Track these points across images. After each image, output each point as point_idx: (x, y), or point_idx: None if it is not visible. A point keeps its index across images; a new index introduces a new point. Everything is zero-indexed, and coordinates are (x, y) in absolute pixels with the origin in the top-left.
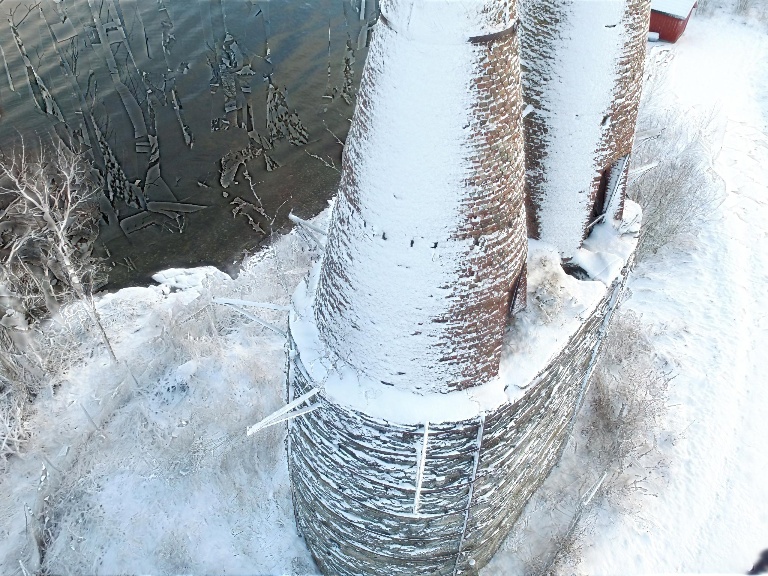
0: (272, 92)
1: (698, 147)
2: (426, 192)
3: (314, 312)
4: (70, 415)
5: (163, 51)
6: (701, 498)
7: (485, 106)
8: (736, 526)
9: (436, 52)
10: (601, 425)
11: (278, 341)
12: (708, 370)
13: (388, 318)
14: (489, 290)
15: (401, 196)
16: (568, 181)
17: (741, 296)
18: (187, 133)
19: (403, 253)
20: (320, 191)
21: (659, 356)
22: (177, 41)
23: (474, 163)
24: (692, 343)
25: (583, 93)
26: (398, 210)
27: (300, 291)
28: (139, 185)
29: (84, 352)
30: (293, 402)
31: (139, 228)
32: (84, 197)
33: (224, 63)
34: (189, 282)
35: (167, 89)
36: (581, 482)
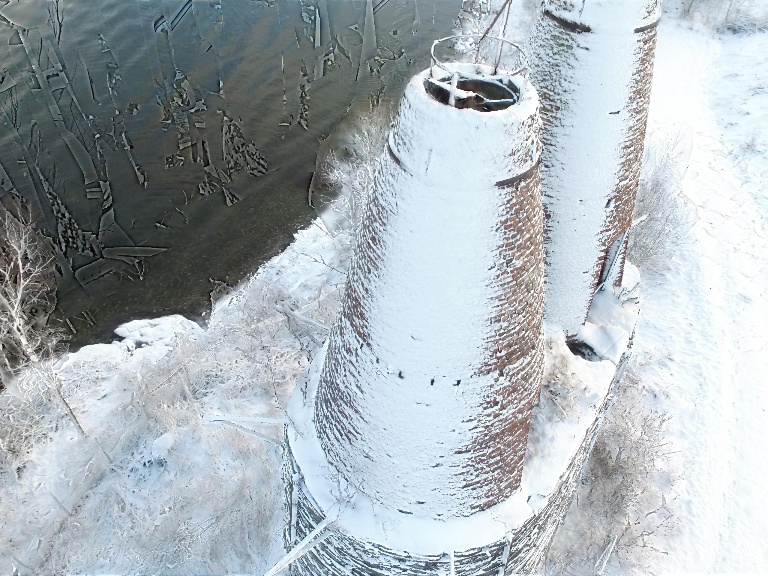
0: (227, 124)
1: (667, 171)
2: (448, 334)
3: (316, 428)
4: (38, 500)
5: (109, 92)
6: (705, 541)
7: (511, 245)
8: (742, 568)
9: (459, 199)
10: (600, 472)
11: (258, 403)
12: (696, 400)
13: (406, 452)
14: (513, 414)
15: (420, 338)
16: (572, 263)
17: (719, 317)
18: (140, 172)
19: (422, 392)
20: (284, 224)
21: (647, 388)
22: (124, 82)
23: (500, 301)
24: (677, 371)
25: (587, 179)
26: (417, 351)
27: (296, 399)
28: (93, 233)
29: (48, 426)
30: (304, 540)
31: (96, 278)
32: (38, 269)
33: (176, 102)
34: (155, 335)
35: (117, 133)
36: (587, 539)
